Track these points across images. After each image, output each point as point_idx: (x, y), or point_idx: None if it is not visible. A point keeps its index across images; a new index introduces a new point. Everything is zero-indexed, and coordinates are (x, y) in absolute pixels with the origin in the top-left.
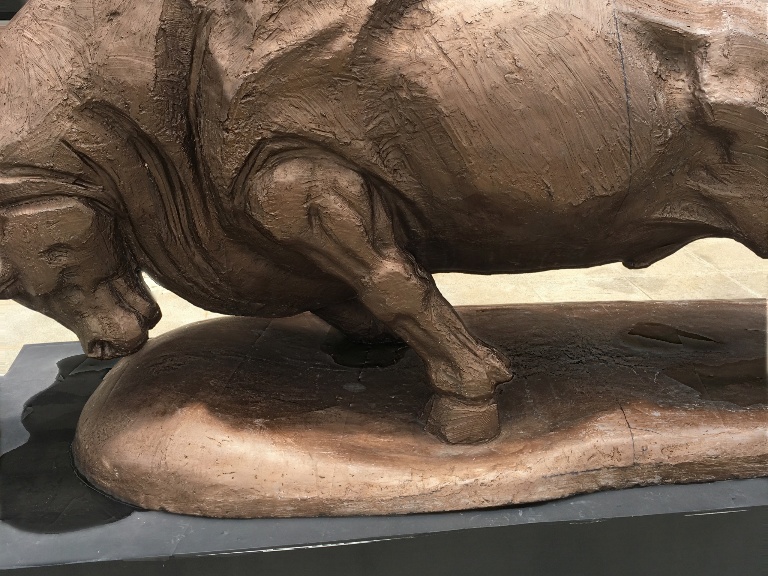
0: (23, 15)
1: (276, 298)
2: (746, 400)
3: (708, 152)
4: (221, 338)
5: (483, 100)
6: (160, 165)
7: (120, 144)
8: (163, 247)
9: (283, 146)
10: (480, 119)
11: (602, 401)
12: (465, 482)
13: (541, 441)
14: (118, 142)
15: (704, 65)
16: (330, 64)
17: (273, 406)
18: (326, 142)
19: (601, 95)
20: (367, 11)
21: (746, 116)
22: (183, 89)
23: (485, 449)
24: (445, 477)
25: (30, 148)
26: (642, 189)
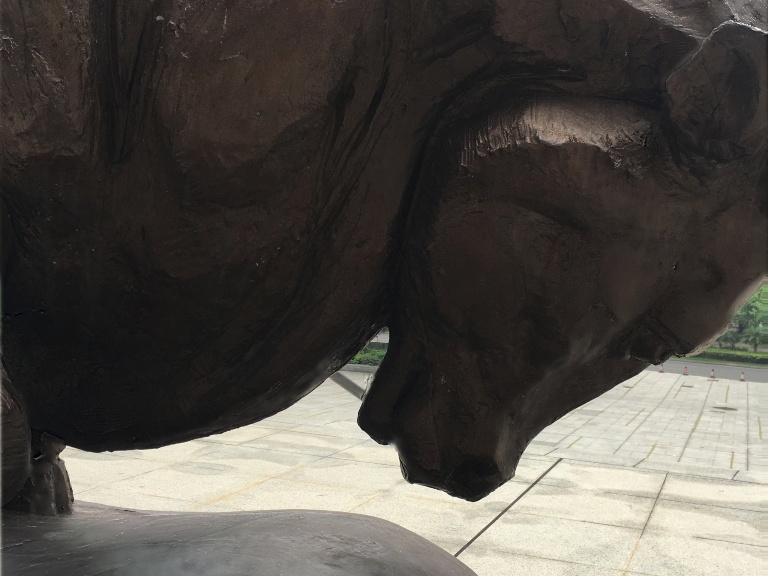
0: None
1: None
2: None
3: None
4: (172, 569)
5: None
6: None
7: None
8: None
9: None
10: None
11: None
12: None
13: None
14: None
15: None
16: None
17: None
18: None
19: None
20: None
21: None
22: None
23: None
24: None
25: None
26: None
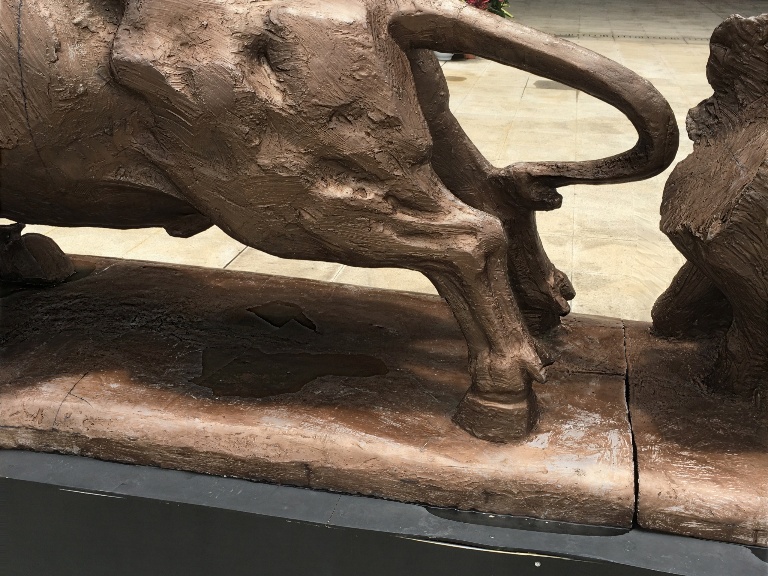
0: None
1: None
2: (231, 390)
3: (145, 113)
4: None
5: None
6: None
7: None
8: None
9: None
10: None
11: (79, 364)
12: None
13: None
14: None
15: (124, 17)
16: None
17: None
18: None
19: None
20: None
21: (144, 75)
22: None
23: None
24: None
25: None
26: (64, 146)
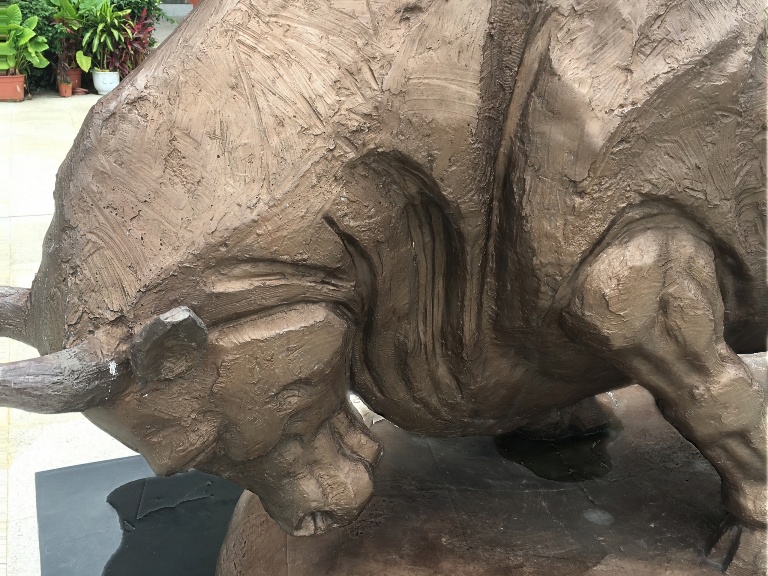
0: (232, 6)
1: (515, 410)
2: None
3: None
4: (393, 459)
5: None
6: (430, 243)
7: (395, 216)
8: (401, 359)
9: (642, 213)
10: None
11: None
12: None
13: None
14: (393, 213)
15: None
16: (720, 92)
17: (543, 569)
18: (693, 205)
19: None
20: (763, 14)
21: None
22: (498, 129)
23: None
24: None
25: (273, 231)
26: None
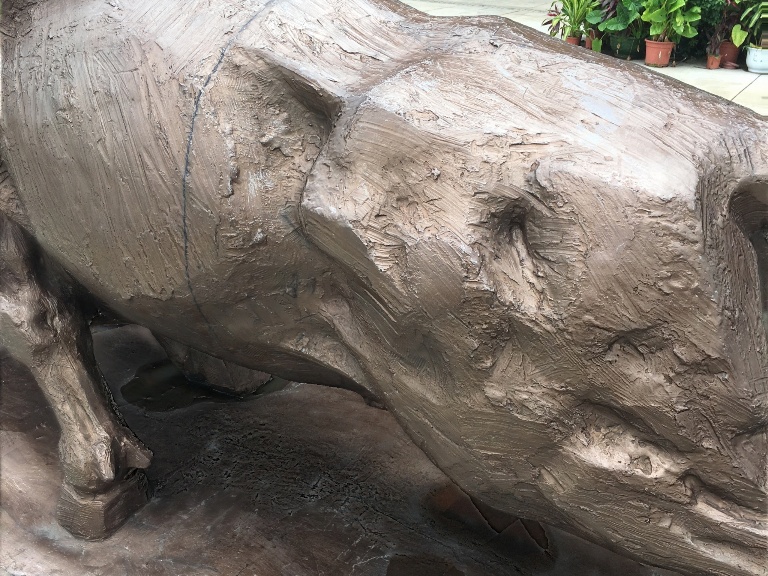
0: None
1: None
2: None
3: (340, 277)
4: None
5: (34, 138)
6: None
7: None
8: None
9: None
10: (30, 161)
11: (230, 557)
12: (14, 572)
13: (122, 569)
14: None
15: (326, 145)
16: None
17: None
18: None
19: (152, 161)
20: None
21: (339, 239)
22: None
23: (78, 547)
24: (5, 556)
25: None
26: (232, 303)
